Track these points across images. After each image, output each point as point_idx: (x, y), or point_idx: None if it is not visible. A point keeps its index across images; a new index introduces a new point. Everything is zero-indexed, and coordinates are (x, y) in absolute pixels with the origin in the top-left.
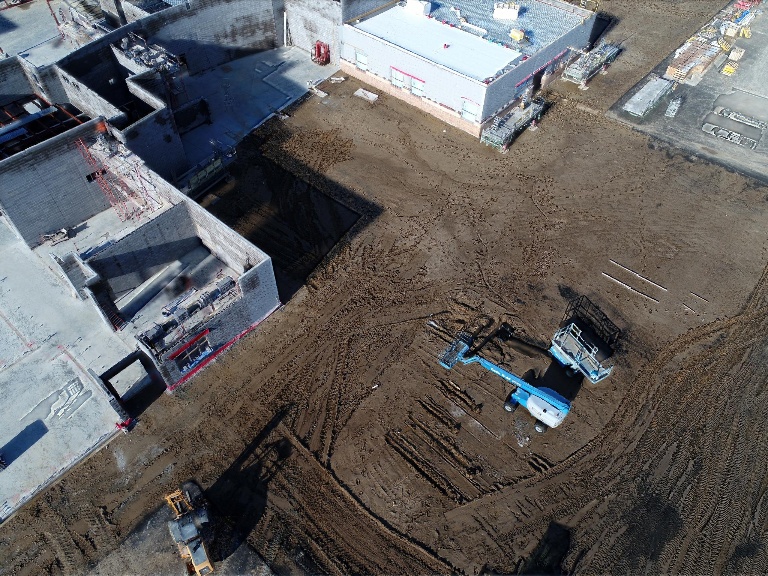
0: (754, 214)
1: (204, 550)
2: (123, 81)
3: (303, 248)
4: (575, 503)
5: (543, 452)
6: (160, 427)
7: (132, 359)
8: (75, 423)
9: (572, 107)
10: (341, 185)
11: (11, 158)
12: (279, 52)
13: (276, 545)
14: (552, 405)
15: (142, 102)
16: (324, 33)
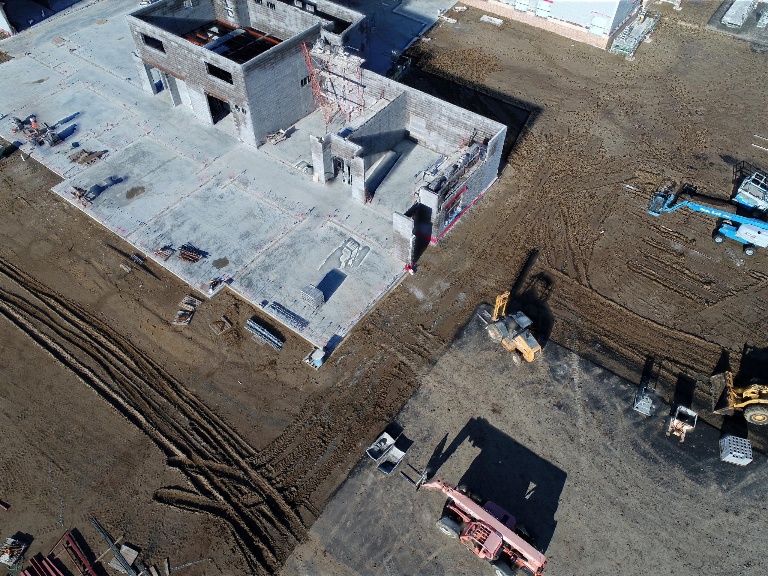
0: None
1: (534, 338)
2: None
3: None
4: None
5: (758, 268)
6: (438, 269)
7: (415, 210)
8: (367, 269)
9: (674, 23)
10: (502, 90)
11: (262, 55)
12: None
13: (575, 341)
14: (763, 228)
15: (331, 18)
16: None
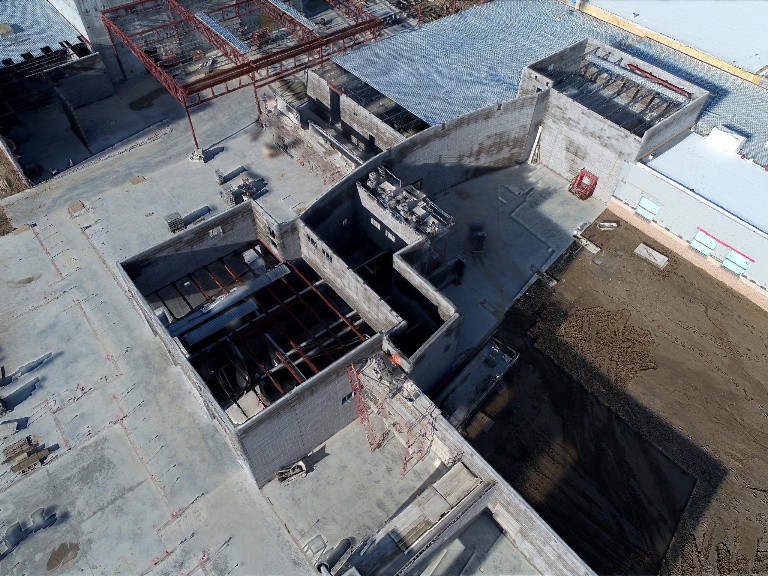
0: None
1: None
2: (357, 220)
3: (628, 536)
4: None
5: None
6: None
7: None
8: None
9: None
10: (653, 416)
11: (274, 406)
12: (523, 172)
13: None
14: None
15: (410, 286)
16: (597, 163)
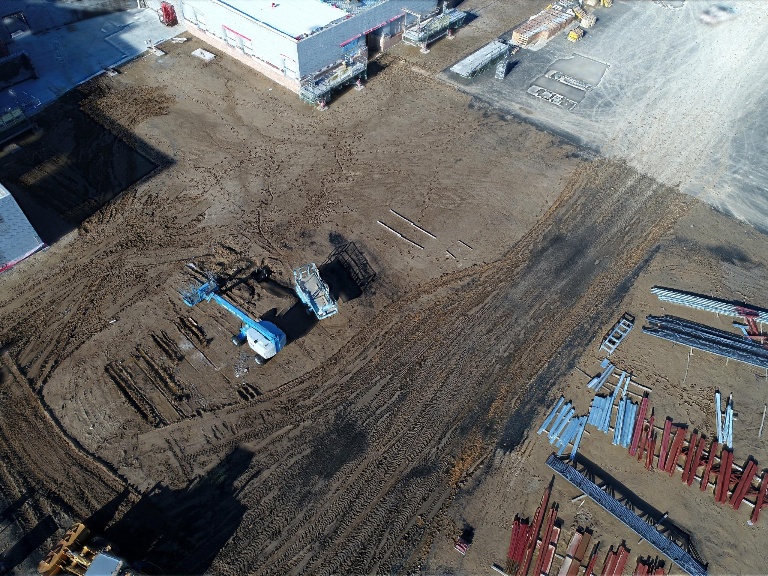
0: (549, 170)
1: None
2: None
3: (88, 195)
4: (270, 428)
5: (256, 382)
6: None
7: None
8: None
9: (406, 69)
10: (148, 138)
11: None
12: (131, 13)
13: None
14: (265, 336)
15: None
16: None
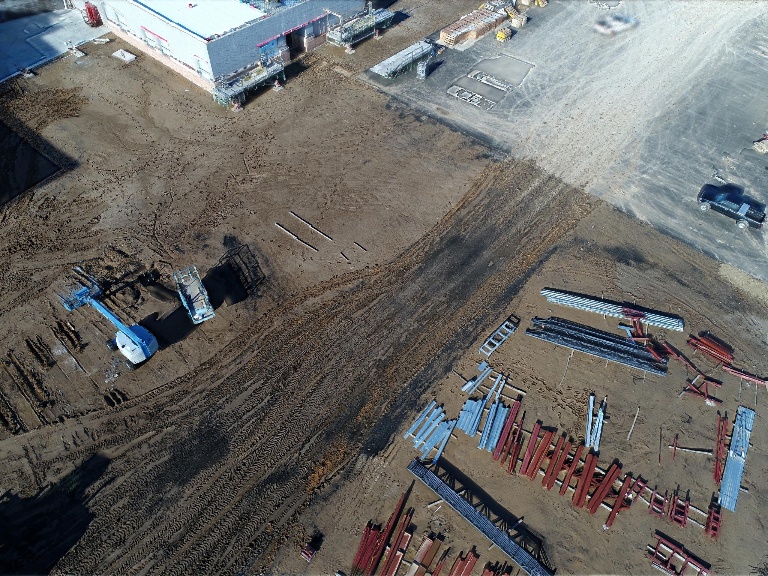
0: (457, 171)
1: None
2: None
3: None
4: (131, 434)
5: (125, 388)
6: None
7: None
8: None
9: (328, 69)
10: (55, 140)
11: None
12: (57, 14)
13: None
14: (133, 341)
15: None
16: None
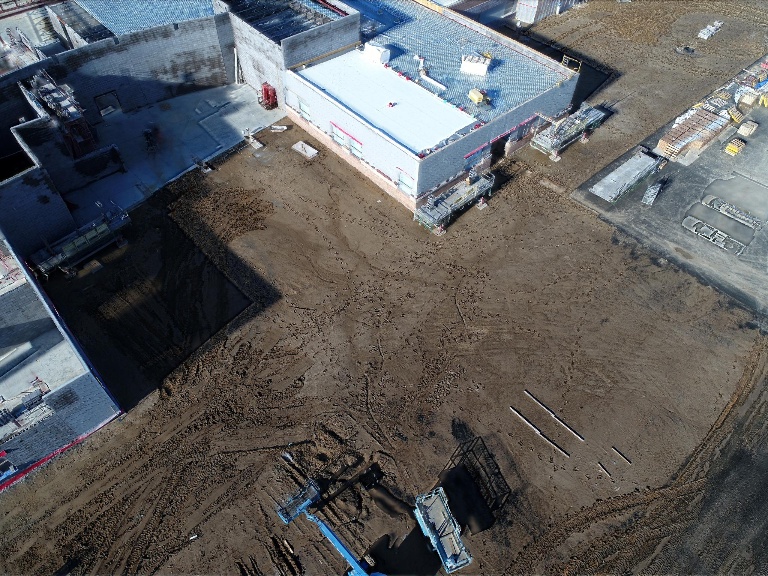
0: (719, 345)
1: None
2: None
3: (173, 339)
4: None
5: None
6: None
7: None
8: None
9: (535, 182)
10: (242, 261)
11: None
12: (228, 90)
13: None
14: None
15: (26, 154)
16: (270, 76)
